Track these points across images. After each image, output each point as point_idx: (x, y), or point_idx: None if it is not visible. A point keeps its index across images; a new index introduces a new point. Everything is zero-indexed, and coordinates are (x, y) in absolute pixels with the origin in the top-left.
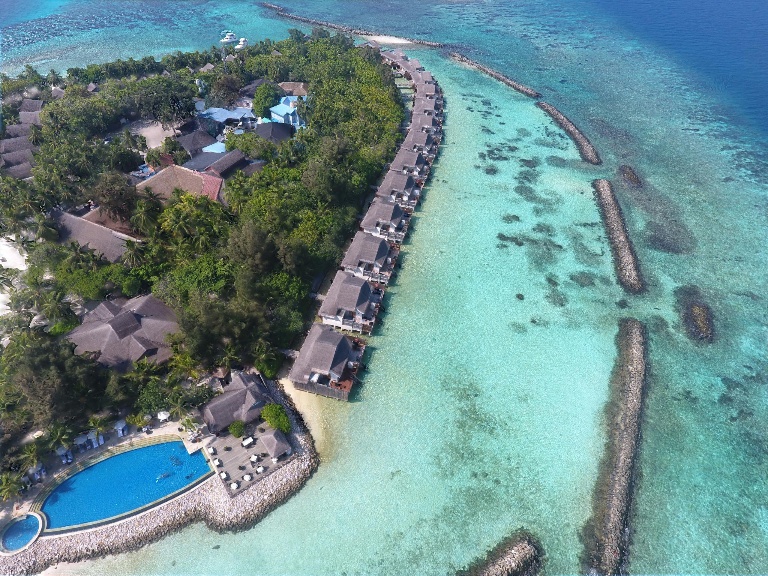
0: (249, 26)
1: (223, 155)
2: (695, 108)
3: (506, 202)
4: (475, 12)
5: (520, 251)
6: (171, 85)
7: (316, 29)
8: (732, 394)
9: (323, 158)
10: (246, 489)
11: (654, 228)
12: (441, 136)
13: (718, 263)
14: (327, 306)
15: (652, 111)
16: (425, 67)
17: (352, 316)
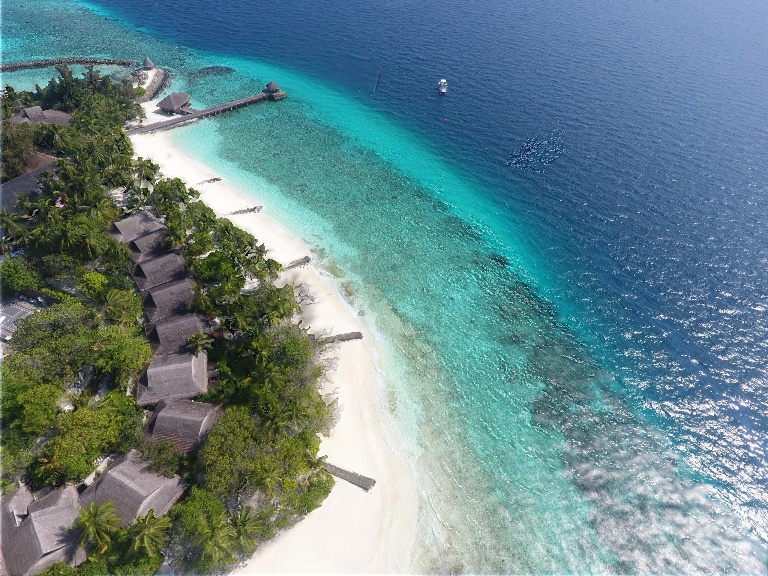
0: None
1: None
2: None
3: None
4: None
5: None
6: None
7: None
8: None
9: None
10: None
11: None
12: None
13: None
14: None
15: None
16: None
17: None
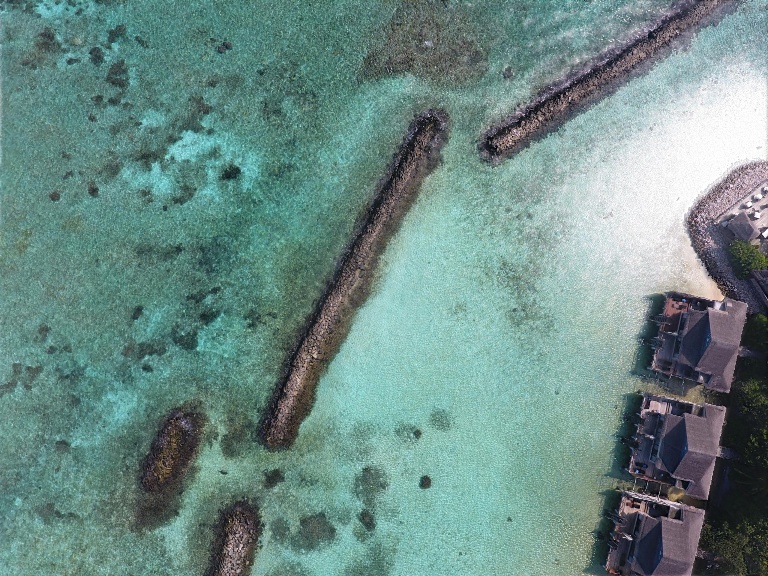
0: None
1: None
2: None
3: None
4: None
5: None
6: None
7: None
8: (196, 325)
9: None
10: (755, 188)
11: None
12: None
13: None
14: (720, 420)
15: None
16: None
17: None
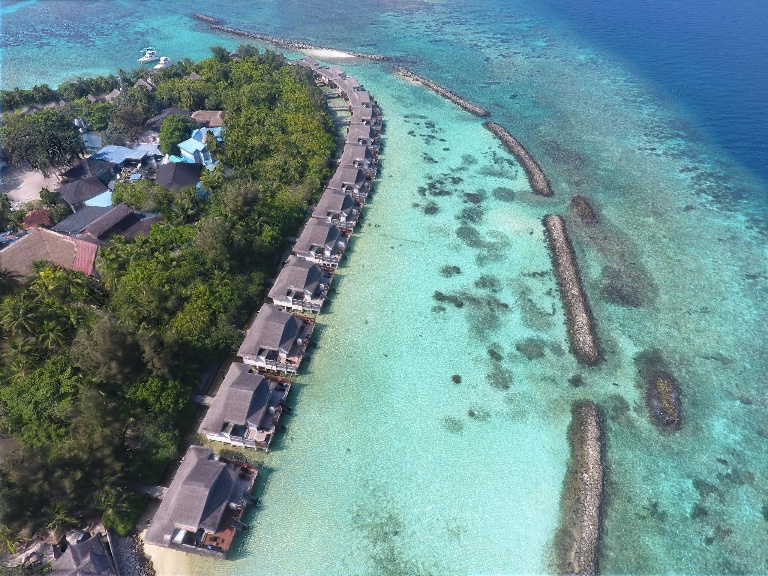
0: (176, 41)
1: (107, 211)
2: (651, 123)
3: (446, 249)
4: (424, 20)
5: (459, 314)
6: (63, 119)
7: (242, 46)
8: (706, 503)
9: (228, 210)
10: None
11: (611, 275)
12: (375, 170)
13: (682, 317)
14: (210, 420)
15: (607, 128)
16: (366, 84)
17: (245, 427)
